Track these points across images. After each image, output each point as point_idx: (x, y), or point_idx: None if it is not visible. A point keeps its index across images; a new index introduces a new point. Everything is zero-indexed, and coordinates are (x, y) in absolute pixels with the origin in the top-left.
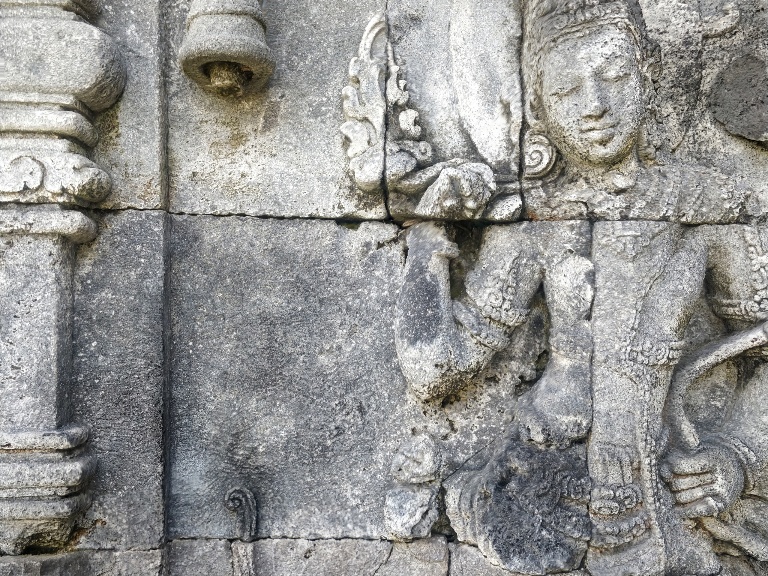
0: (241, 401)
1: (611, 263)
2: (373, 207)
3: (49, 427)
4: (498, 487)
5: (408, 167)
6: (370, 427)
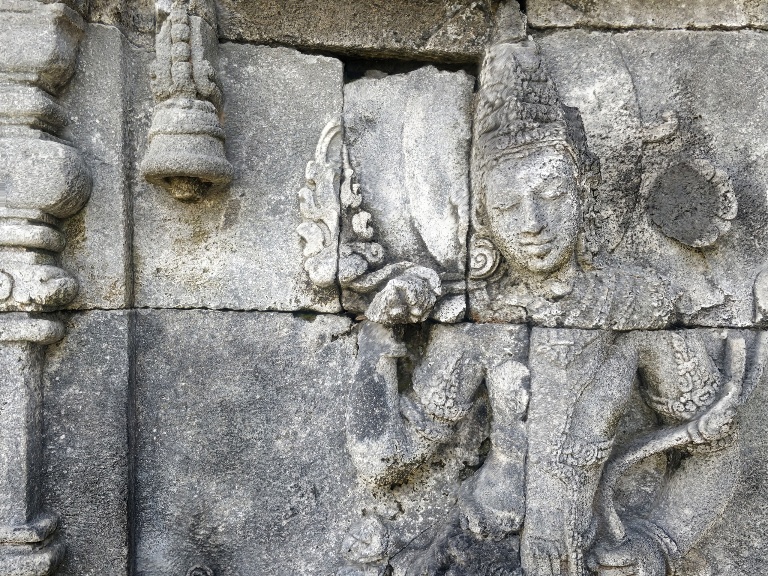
0: (202, 484)
1: (546, 370)
2: (328, 302)
3: (19, 521)
4: (438, 573)
5: (359, 271)
6: (323, 508)
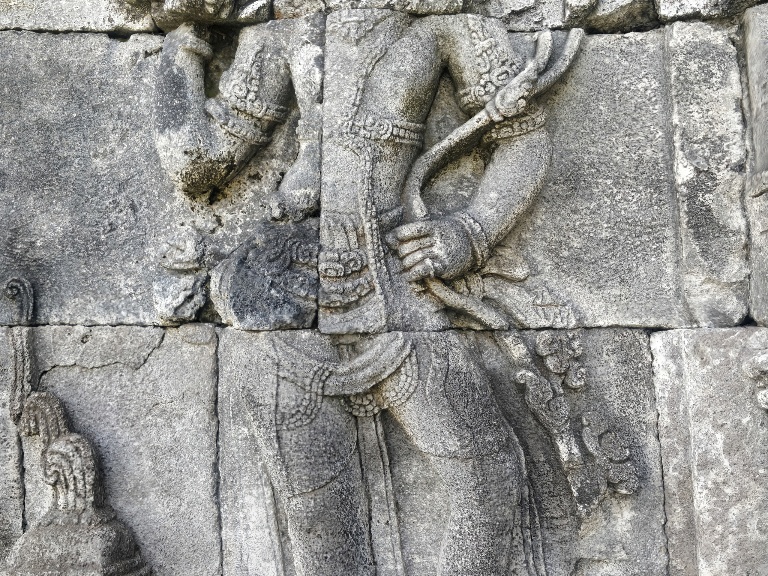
0: (19, 200)
1: (338, 48)
2: (140, 19)
3: None
4: (243, 261)
5: None
6: (142, 223)
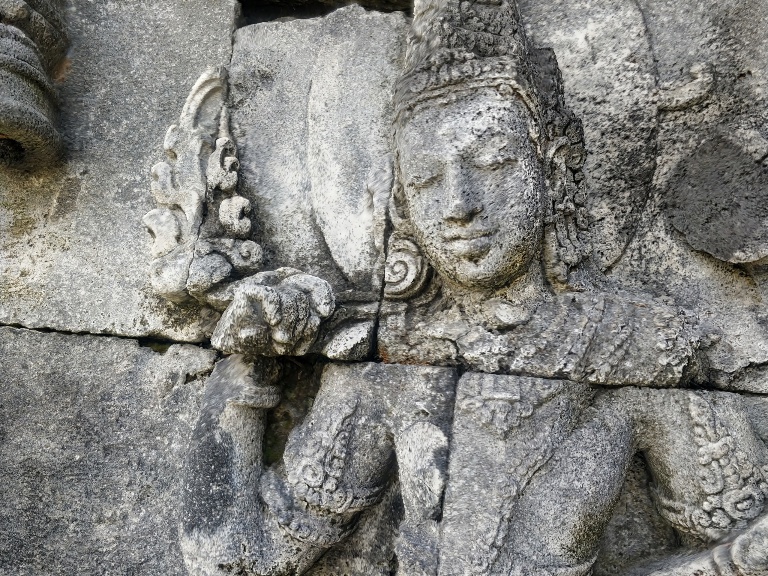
0: None
1: (473, 438)
2: (185, 325)
3: None
4: None
5: (215, 276)
6: None
